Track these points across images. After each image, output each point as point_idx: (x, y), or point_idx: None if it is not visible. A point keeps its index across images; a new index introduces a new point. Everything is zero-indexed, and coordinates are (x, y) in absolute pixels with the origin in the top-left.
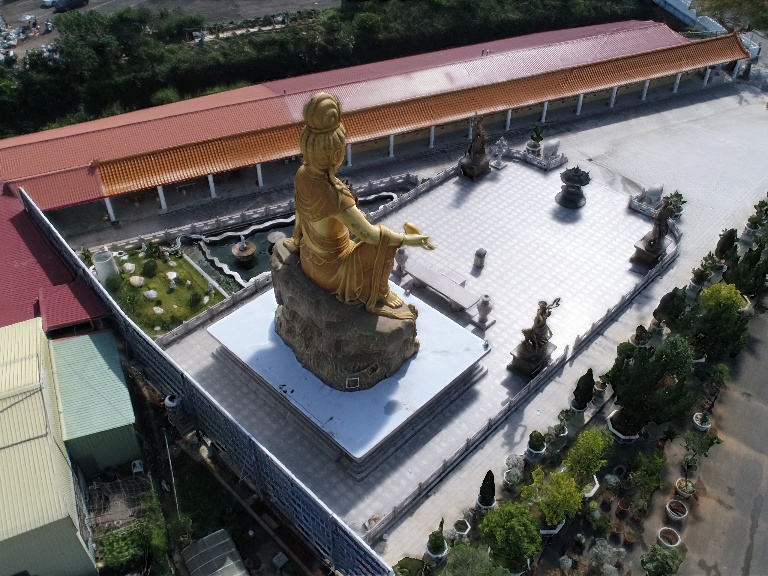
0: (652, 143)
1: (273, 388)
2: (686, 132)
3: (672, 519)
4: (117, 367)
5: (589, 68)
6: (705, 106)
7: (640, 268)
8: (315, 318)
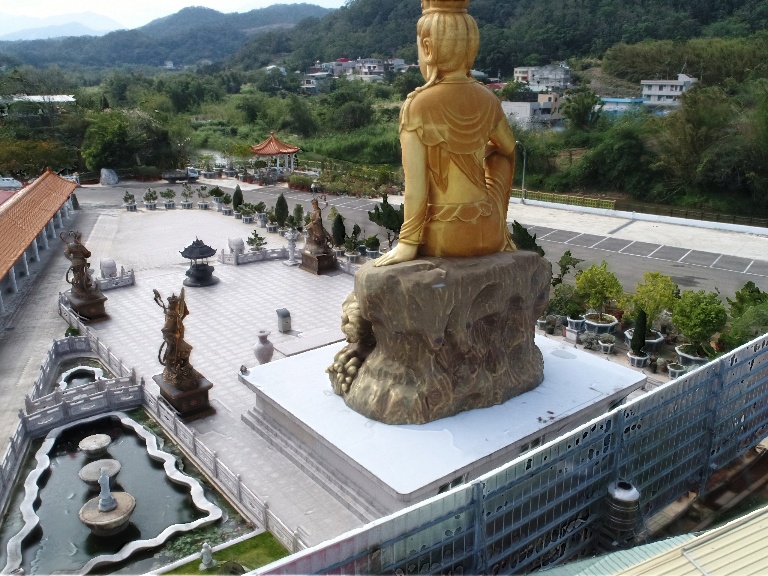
0: (135, 248)
1: (544, 430)
2: (134, 236)
3: (616, 307)
4: (553, 575)
5: (14, 209)
6: (102, 224)
7: (331, 273)
8: (521, 285)
